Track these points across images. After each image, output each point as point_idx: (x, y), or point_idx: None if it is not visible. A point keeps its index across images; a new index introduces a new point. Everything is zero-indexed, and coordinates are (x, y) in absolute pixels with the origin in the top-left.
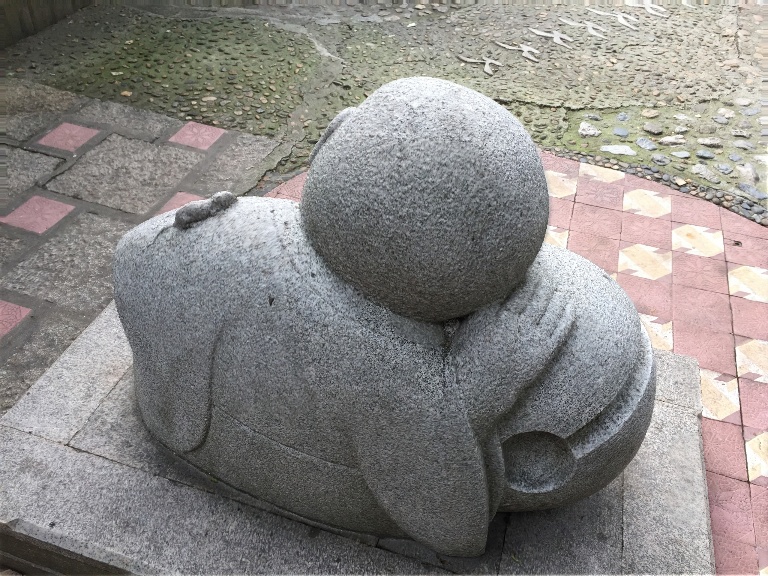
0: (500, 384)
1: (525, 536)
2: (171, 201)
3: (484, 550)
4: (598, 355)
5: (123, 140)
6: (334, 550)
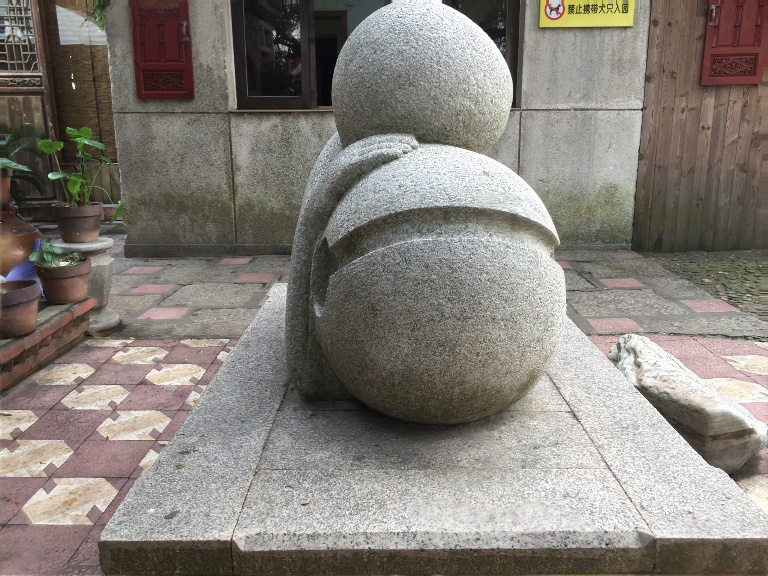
0: (322, 182)
1: (336, 419)
2: (613, 319)
3: (296, 378)
4: (379, 184)
5: (649, 292)
6: (285, 357)
